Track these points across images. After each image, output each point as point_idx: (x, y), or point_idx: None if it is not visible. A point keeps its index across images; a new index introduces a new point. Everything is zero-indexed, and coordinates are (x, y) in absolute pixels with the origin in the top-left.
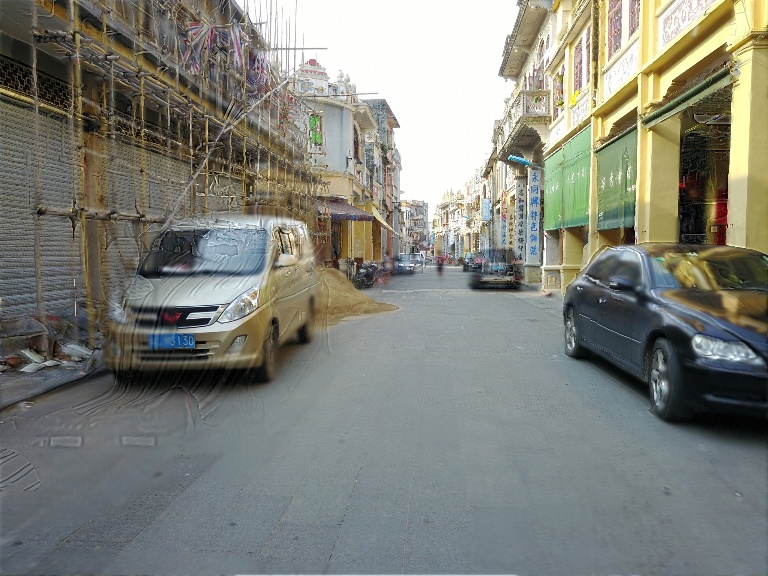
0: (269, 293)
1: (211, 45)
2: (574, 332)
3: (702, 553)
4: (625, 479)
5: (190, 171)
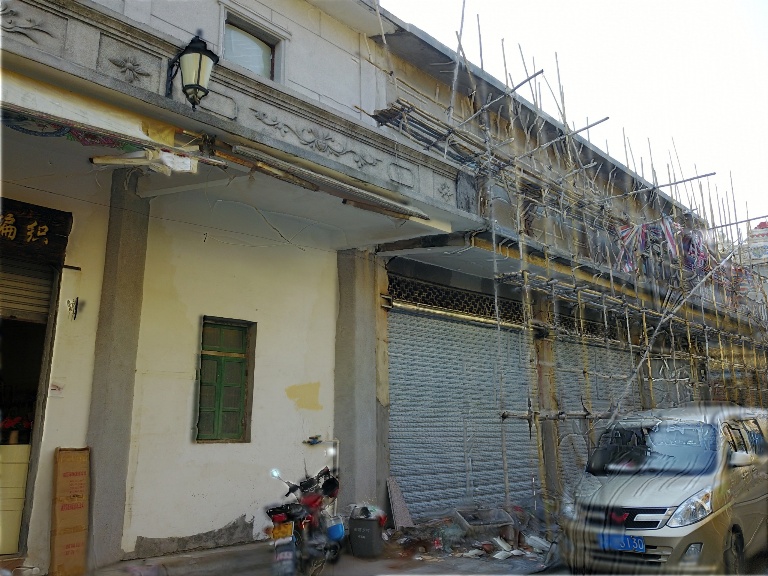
0: (724, 496)
1: (643, 241)
2: None
3: None
4: None
5: (635, 360)
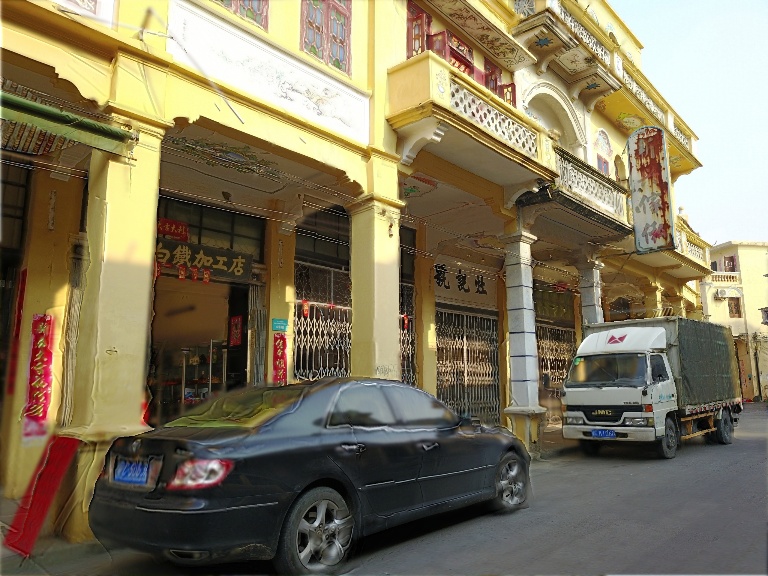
0: None
1: None
2: (345, 525)
3: (649, 488)
4: (631, 498)
5: None
